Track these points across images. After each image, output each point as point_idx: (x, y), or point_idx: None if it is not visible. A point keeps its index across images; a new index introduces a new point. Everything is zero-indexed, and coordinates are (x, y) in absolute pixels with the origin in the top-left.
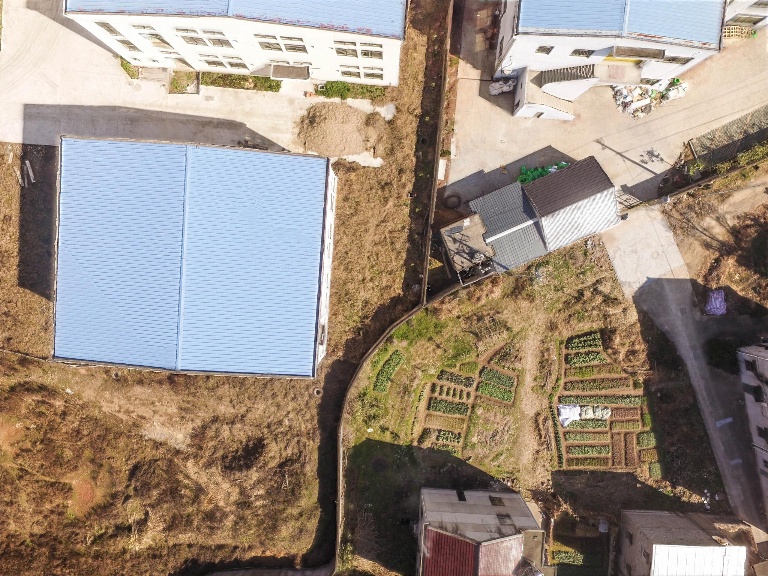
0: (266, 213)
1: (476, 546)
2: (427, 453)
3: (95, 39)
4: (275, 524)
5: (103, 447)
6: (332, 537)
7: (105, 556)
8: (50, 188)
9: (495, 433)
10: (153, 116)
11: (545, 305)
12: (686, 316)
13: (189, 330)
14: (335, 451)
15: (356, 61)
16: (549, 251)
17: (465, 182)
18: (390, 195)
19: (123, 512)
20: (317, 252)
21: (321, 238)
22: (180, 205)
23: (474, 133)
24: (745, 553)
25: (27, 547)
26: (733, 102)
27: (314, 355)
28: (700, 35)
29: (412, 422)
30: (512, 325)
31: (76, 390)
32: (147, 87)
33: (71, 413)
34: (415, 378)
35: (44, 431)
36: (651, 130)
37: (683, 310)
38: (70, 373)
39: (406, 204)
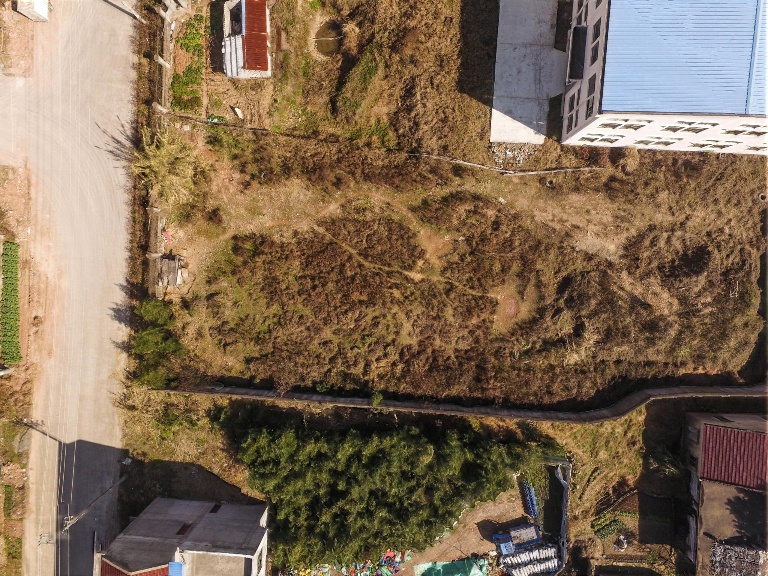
0: None
1: None
2: None
3: None
4: (724, 332)
5: (535, 258)
6: (766, 354)
7: (537, 369)
8: None
9: None
10: None
11: None
12: None
13: (762, 71)
14: None
15: None
16: None
17: None
18: None
19: (552, 326)
20: None
21: None
22: None
23: None
24: None
25: (454, 362)
26: None
27: None
28: None
29: None
30: None
31: (509, 199)
32: None
33: (503, 223)
34: None
35: (475, 242)
36: None
37: None
38: (503, 182)
39: None
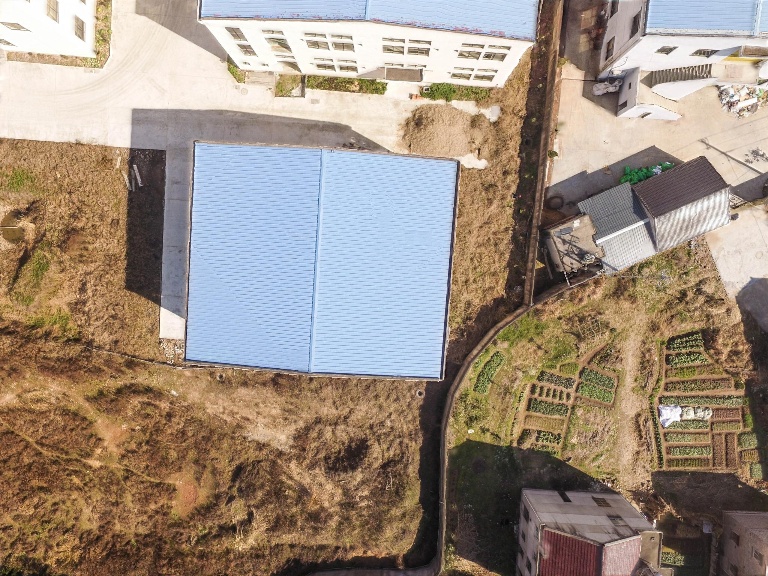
0: (398, 216)
1: (599, 547)
2: (526, 454)
3: (202, 43)
4: (380, 525)
5: (207, 448)
6: (432, 537)
7: (210, 556)
8: (157, 192)
9: (595, 434)
10: (259, 120)
11: (647, 306)
12: None
13: (322, 333)
14: (436, 452)
15: (474, 63)
16: (658, 252)
17: (568, 183)
18: (494, 196)
19: (227, 512)
20: (446, 255)
21: (451, 241)
22: (314, 209)
23: (577, 134)
24: None
25: (132, 547)
26: None
27: (442, 357)
28: None
29: (512, 423)
30: (613, 326)
31: (181, 392)
32: (254, 91)
33: (176, 415)
34: (516, 379)
35: (149, 432)
36: (757, 129)
37: None
38: (175, 375)
39: (510, 205)
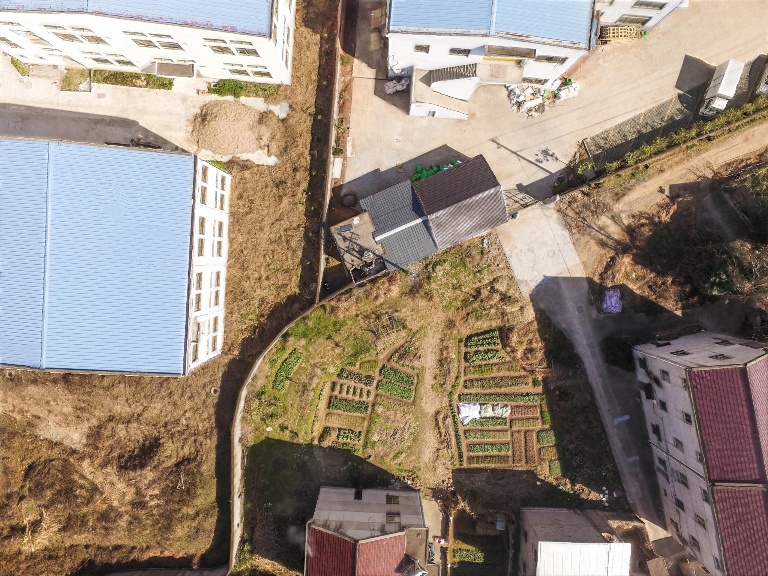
0: (132, 210)
1: (354, 544)
2: (328, 452)
3: None
4: (170, 524)
5: None
6: None
7: None
8: None
9: (395, 431)
10: (44, 113)
11: (443, 303)
12: (583, 314)
13: (54, 328)
14: None
15: (236, 59)
16: (440, 249)
17: (361, 181)
18: (285, 193)
19: (18, 513)
20: (186, 249)
21: (190, 235)
22: (43, 202)
23: (370, 132)
24: (630, 549)
25: None
26: (626, 102)
27: (184, 353)
28: (569, 35)
29: (312, 421)
30: (411, 323)
31: None
32: (38, 84)
33: None
34: (314, 377)
35: None
36: (545, 129)
37: (580, 308)
38: None
39: (301, 202)
